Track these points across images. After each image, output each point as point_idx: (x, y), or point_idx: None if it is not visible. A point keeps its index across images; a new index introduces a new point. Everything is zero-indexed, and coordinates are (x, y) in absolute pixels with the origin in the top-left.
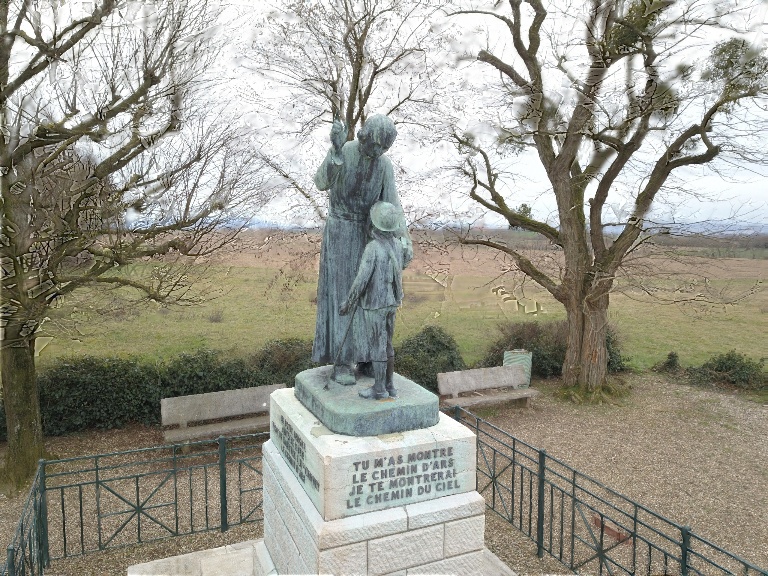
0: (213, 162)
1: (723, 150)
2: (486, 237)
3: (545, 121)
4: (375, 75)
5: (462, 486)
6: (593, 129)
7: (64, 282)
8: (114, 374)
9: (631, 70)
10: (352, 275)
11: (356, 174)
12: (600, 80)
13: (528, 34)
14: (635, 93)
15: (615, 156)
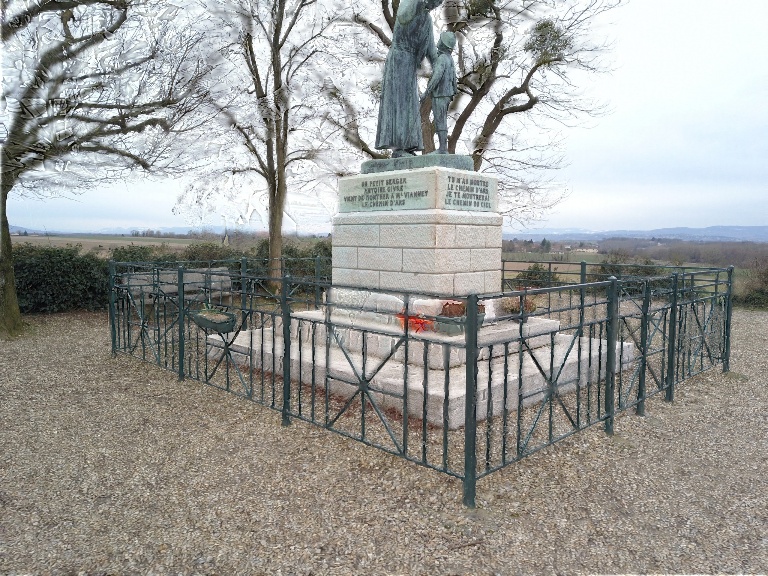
0: (193, 51)
1: (540, 100)
2: None
3: (423, 65)
4: (301, 7)
5: (491, 208)
6: (460, 73)
7: None
8: (60, 258)
9: (501, 21)
10: (409, 89)
11: (417, 20)
12: (480, 26)
13: (391, 5)
14: (486, 50)
15: (470, 99)
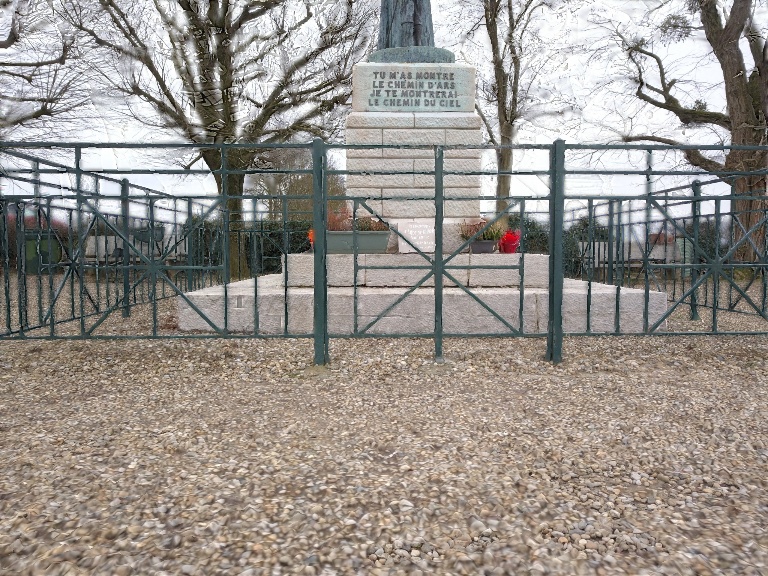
0: (365, 27)
1: None
2: (650, 131)
3: None
4: None
5: (463, 106)
6: None
7: (262, 135)
8: (300, 228)
9: None
10: None
11: None
12: None
13: None
14: None
15: None
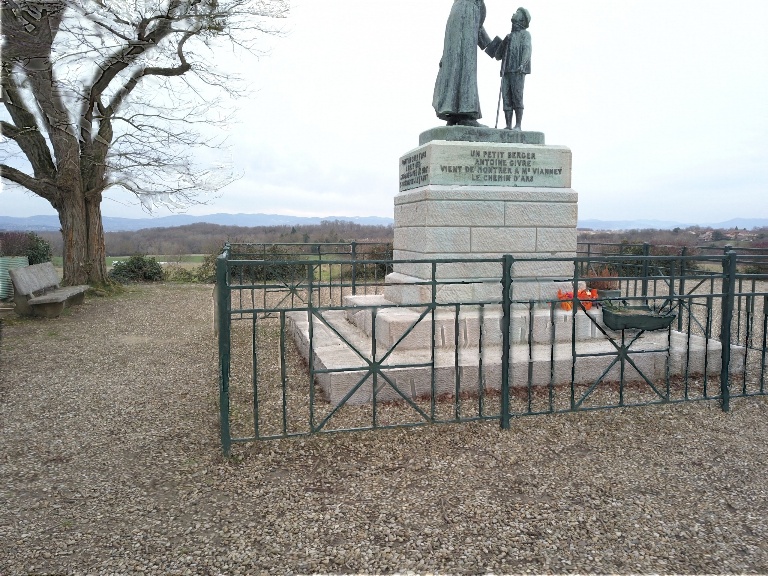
0: None
1: (191, 68)
2: None
3: None
4: None
5: None
6: (148, 12)
7: None
8: None
9: None
10: None
11: None
12: None
13: None
14: None
15: None
